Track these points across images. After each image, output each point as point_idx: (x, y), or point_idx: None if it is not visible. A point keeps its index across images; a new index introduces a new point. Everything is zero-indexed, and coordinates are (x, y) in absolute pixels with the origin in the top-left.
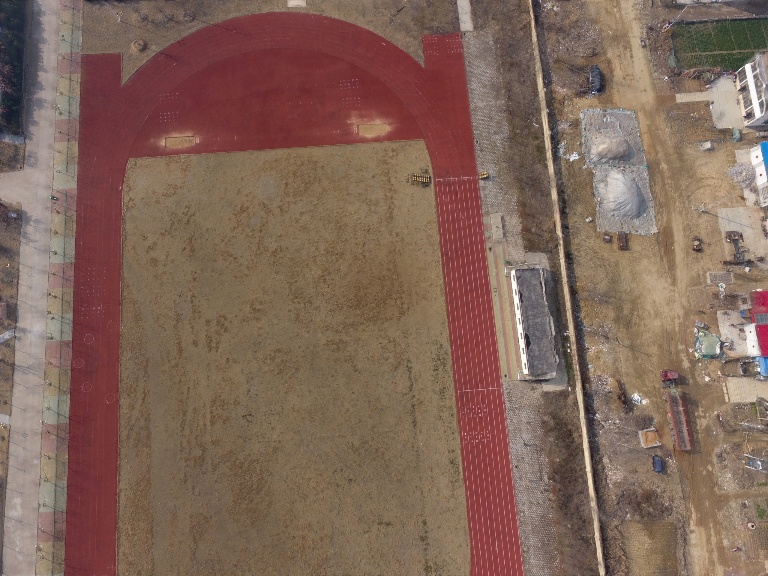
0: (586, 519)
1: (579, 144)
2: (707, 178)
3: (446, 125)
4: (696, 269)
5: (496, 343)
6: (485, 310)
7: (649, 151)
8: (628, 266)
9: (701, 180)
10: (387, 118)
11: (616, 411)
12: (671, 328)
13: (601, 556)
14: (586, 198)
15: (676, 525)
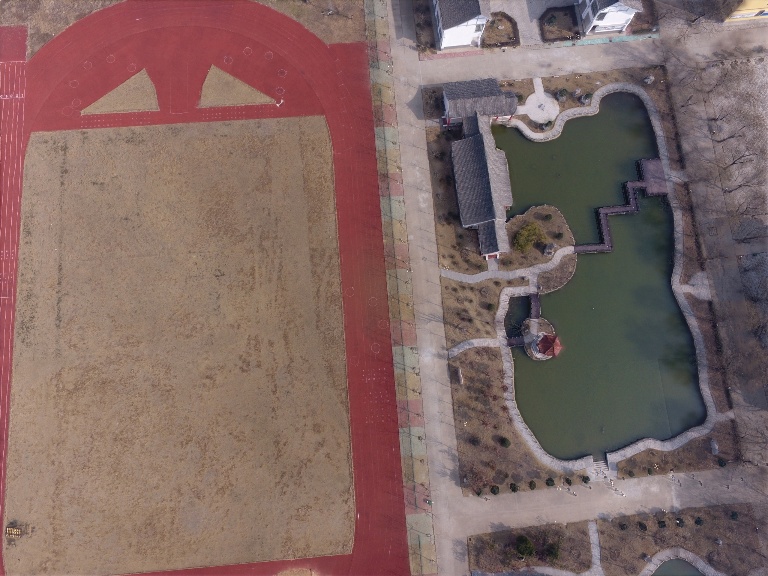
0: None
1: None
2: None
3: None
4: None
5: None
6: None
7: None
8: None
9: None
10: None
11: None
12: None
13: None
14: None
15: None
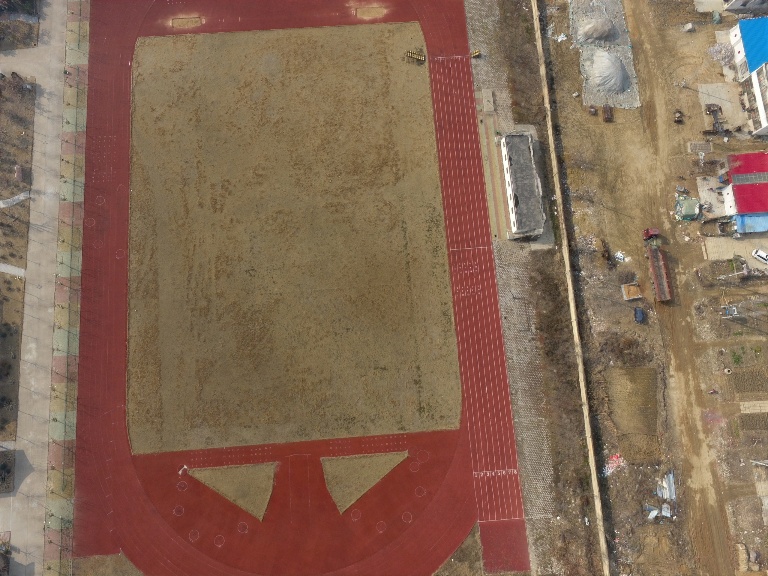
0: (571, 365)
1: (567, 26)
2: (688, 57)
3: (440, 9)
4: (677, 139)
5: (487, 206)
6: (476, 176)
7: (633, 33)
8: (612, 137)
9: (683, 59)
10: (384, 2)
11: (600, 268)
12: (653, 193)
13: (585, 396)
14: (573, 75)
15: (656, 370)
